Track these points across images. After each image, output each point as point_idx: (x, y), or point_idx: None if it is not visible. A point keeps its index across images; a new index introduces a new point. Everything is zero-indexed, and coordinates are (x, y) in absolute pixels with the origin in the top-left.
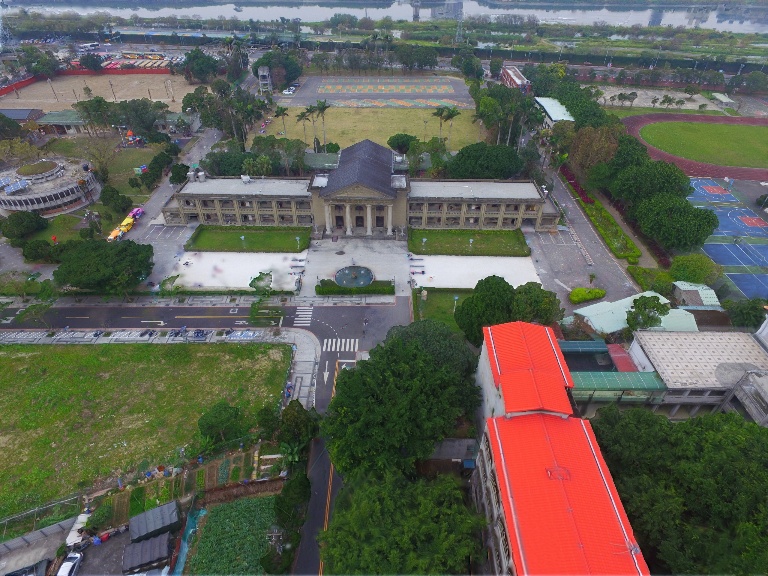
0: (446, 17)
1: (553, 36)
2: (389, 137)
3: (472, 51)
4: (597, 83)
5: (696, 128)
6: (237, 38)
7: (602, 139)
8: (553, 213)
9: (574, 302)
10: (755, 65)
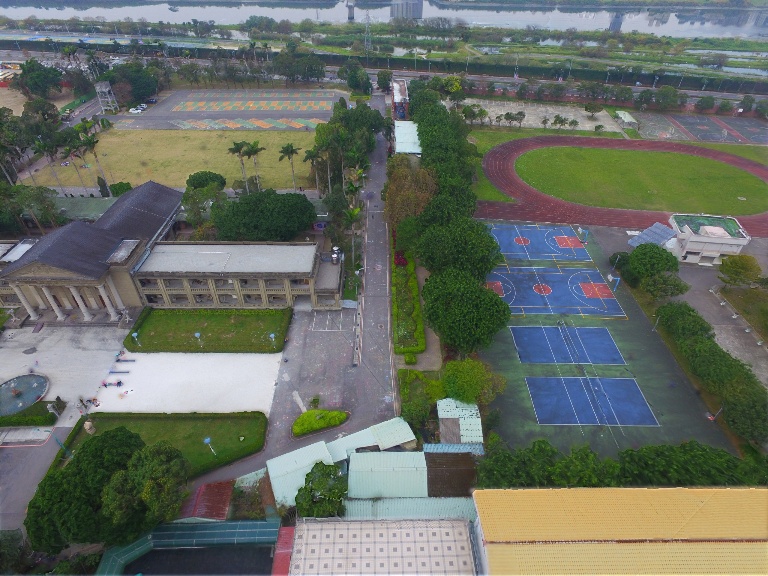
0: (352, 21)
1: (479, 41)
2: (210, 171)
3: (358, 62)
4: (497, 98)
5: (583, 155)
6: (117, 44)
7: (412, 187)
8: (328, 289)
9: (295, 434)
10: (674, 77)
